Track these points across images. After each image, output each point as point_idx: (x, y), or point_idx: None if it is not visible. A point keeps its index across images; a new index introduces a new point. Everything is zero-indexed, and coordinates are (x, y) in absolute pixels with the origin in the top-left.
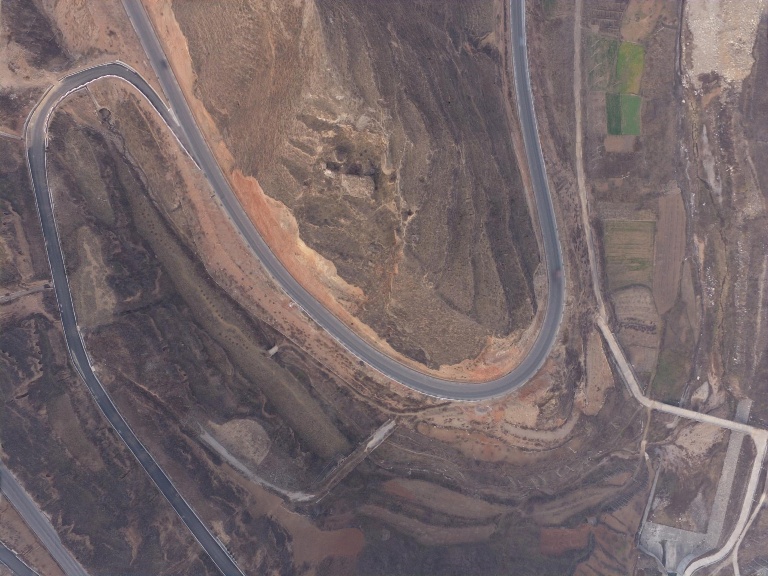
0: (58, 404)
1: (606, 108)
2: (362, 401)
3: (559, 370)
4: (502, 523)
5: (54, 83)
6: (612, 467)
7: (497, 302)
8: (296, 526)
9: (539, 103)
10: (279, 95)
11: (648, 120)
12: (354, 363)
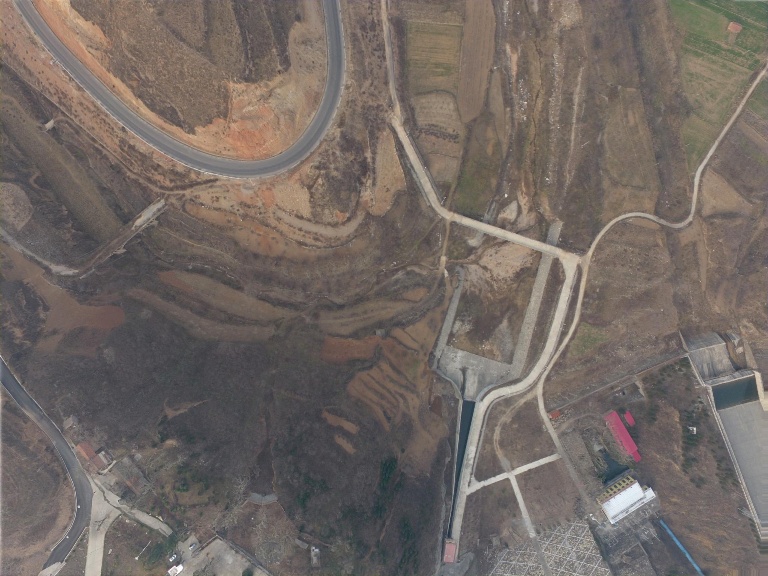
0: None
1: None
2: (133, 179)
3: (328, 149)
4: (283, 326)
5: None
6: (408, 281)
7: (233, 43)
8: (56, 299)
9: None
10: None
11: None
12: (116, 129)
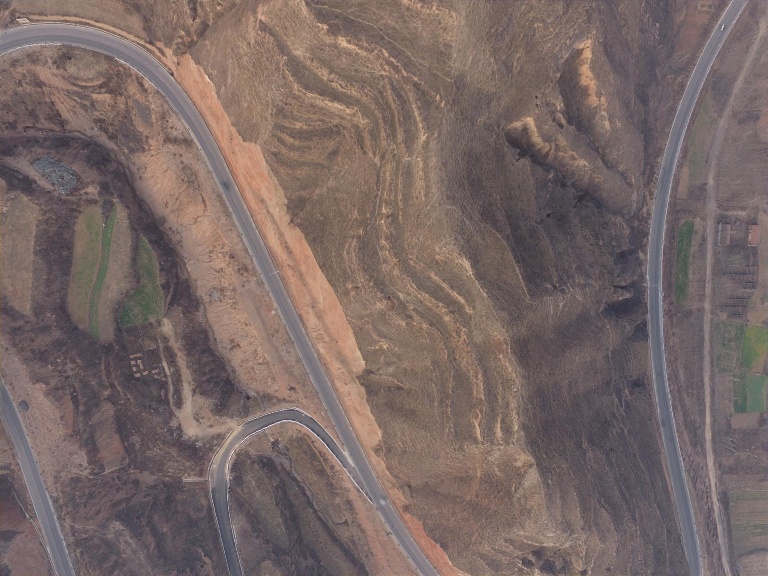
0: None
1: (733, 388)
2: None
3: None
4: None
5: (235, 428)
6: None
7: None
8: None
9: (675, 400)
10: (483, 509)
11: None
12: None
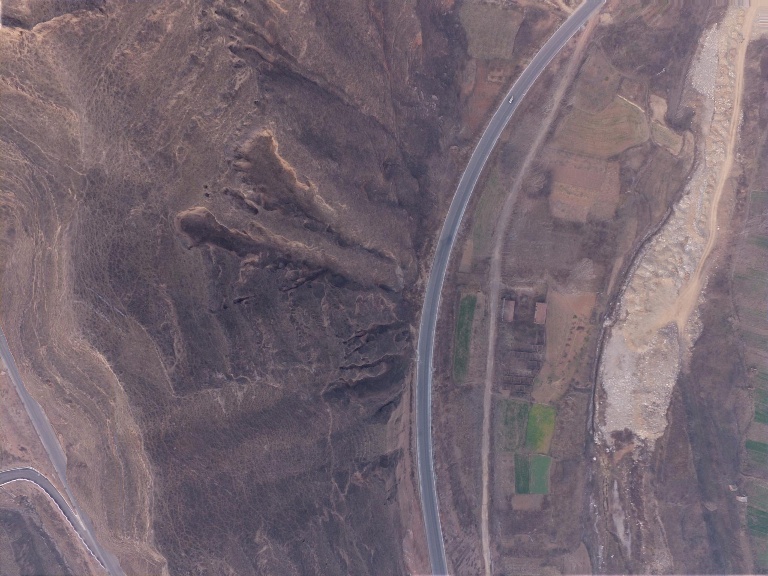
0: None
1: (515, 468)
2: None
3: None
4: None
5: None
6: None
7: None
8: None
9: (442, 479)
10: None
11: (556, 481)
12: None
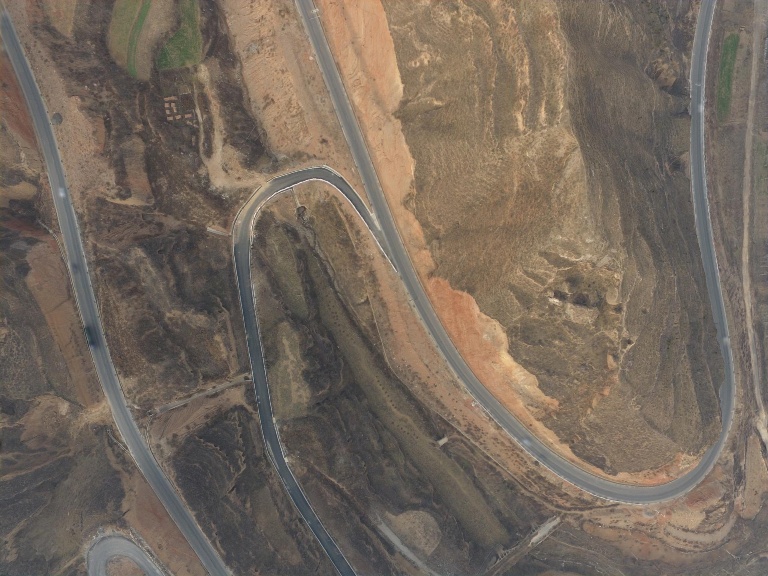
0: (260, 497)
1: None
2: (528, 496)
3: (730, 479)
4: None
5: (262, 184)
6: (761, 568)
7: (693, 421)
8: None
9: (713, 210)
10: (517, 228)
11: None
12: (529, 463)
